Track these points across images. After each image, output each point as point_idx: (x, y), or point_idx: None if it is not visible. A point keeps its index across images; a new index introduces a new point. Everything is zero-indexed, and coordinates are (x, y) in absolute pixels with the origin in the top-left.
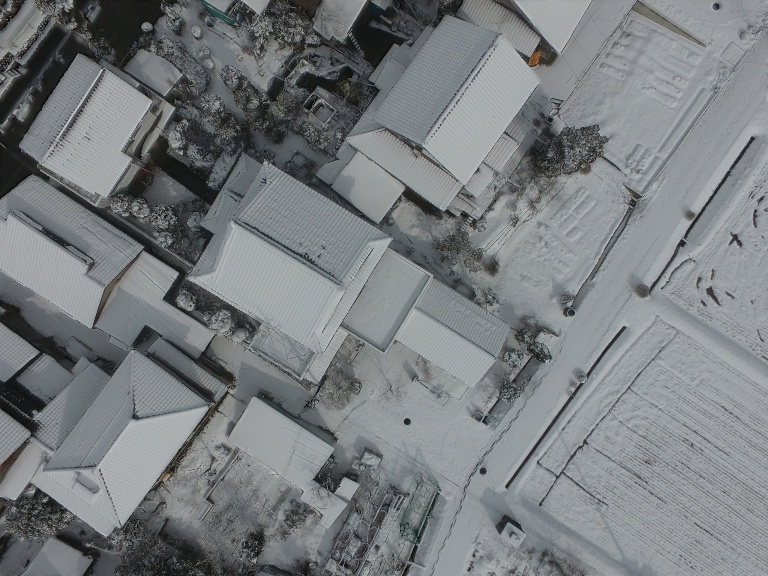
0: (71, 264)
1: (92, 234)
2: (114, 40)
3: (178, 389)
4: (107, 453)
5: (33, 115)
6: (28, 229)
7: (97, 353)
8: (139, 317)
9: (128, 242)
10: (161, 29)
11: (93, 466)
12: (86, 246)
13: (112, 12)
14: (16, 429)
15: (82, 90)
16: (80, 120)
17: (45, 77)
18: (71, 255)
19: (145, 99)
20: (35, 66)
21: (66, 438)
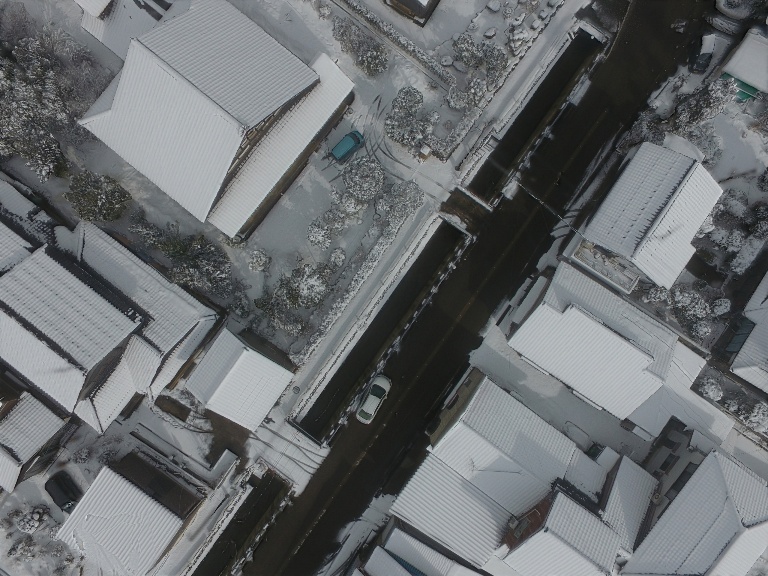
0: (632, 359)
1: (635, 324)
2: (606, 115)
3: (765, 492)
4: (718, 563)
5: (522, 193)
6: (591, 323)
7: (592, 438)
8: (668, 408)
9: (666, 332)
10: (661, 105)
11: (699, 575)
12: (634, 338)
13: (602, 86)
14: (610, 535)
15: (669, 183)
16: (668, 214)
17: (534, 154)
18: (639, 351)
19: (719, 190)
20: (506, 140)
21: (644, 541)
